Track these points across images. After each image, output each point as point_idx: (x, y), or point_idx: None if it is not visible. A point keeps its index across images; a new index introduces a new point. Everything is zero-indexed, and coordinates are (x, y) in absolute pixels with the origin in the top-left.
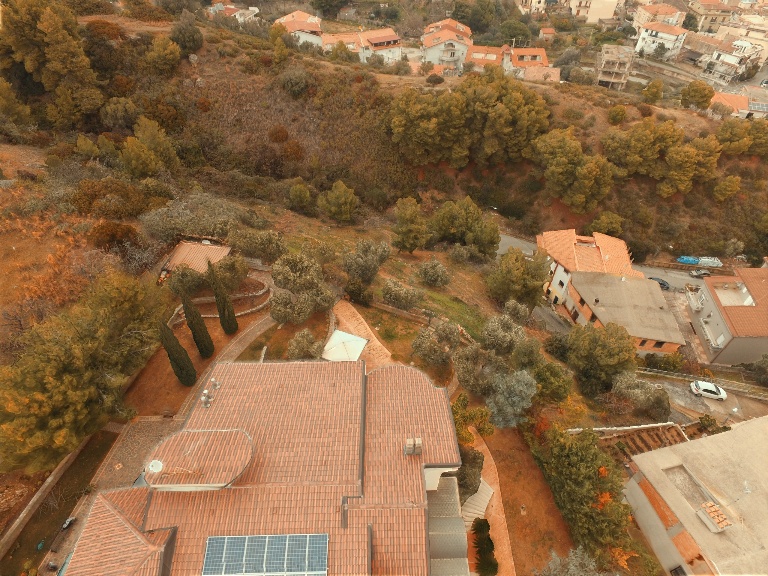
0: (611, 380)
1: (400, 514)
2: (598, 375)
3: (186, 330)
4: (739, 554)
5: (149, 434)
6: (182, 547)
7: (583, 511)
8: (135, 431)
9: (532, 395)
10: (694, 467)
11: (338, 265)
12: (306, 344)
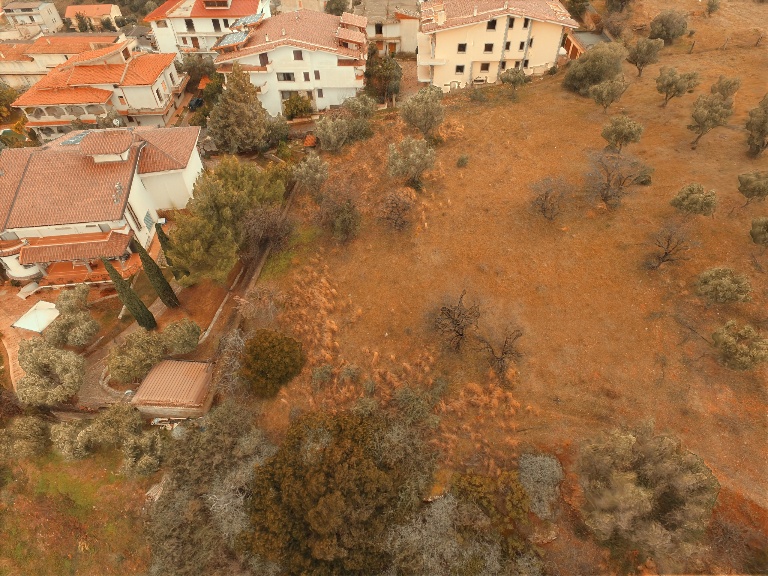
0: None
1: None
2: None
3: None
4: None
5: None
6: None
7: None
8: None
9: None
10: None
11: (4, 466)
12: None
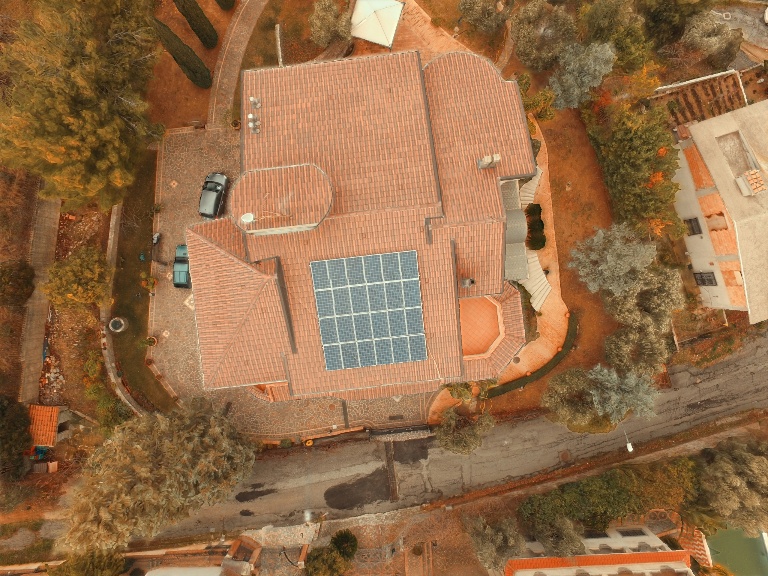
0: (684, 24)
1: (480, 229)
2: (670, 18)
3: (169, 8)
4: (760, 213)
5: (188, 148)
6: (289, 271)
7: (634, 192)
8: (172, 146)
9: (606, 72)
10: (749, 133)
11: None
12: (331, 21)
